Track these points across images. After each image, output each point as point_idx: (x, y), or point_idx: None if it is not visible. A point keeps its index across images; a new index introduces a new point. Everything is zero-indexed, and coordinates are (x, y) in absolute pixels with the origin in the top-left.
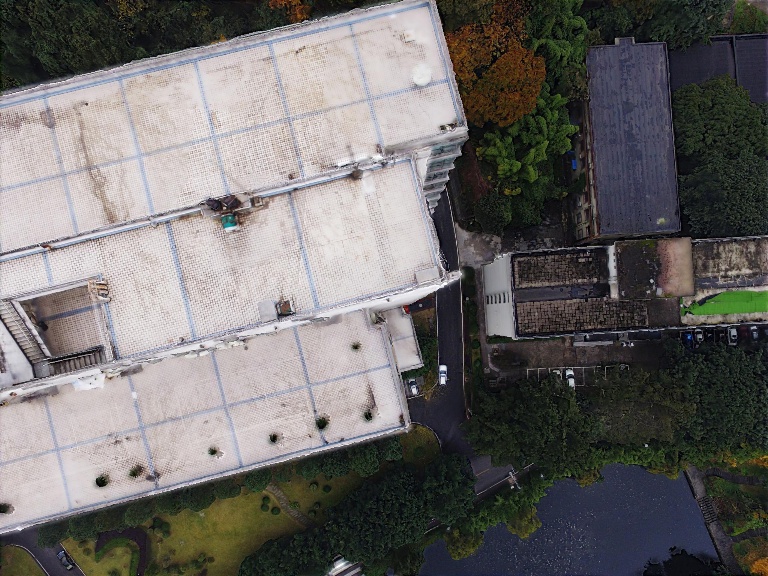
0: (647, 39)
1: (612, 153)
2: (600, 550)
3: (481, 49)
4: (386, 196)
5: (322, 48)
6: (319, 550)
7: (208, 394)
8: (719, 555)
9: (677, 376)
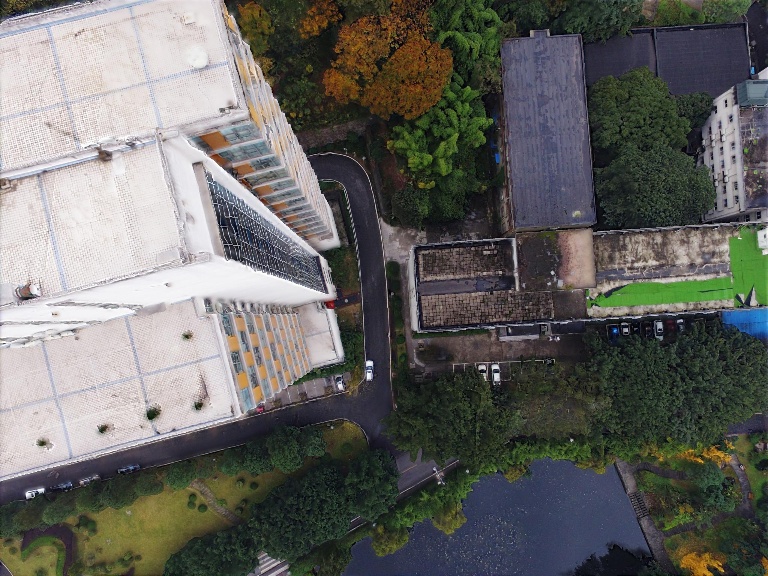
0: (563, 31)
1: (527, 146)
2: (531, 546)
3: (377, 41)
4: (135, 177)
5: (101, 31)
6: (241, 547)
7: (38, 385)
8: (651, 550)
9: (592, 369)
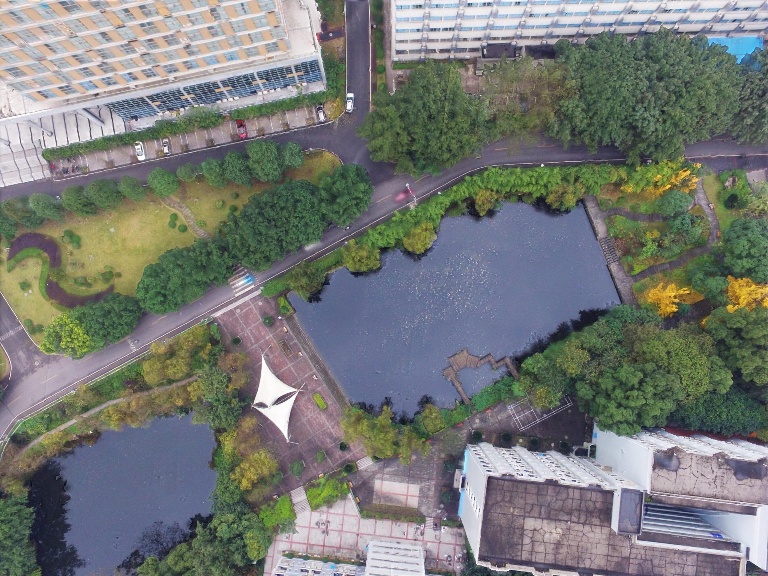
0: None
1: None
2: (501, 286)
3: None
4: None
5: None
6: (216, 249)
7: None
8: (620, 296)
9: (560, 60)
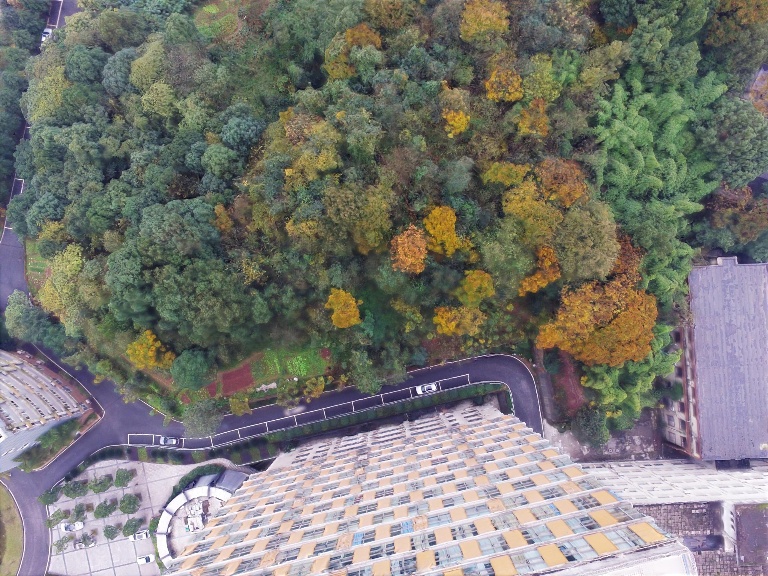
0: (749, 257)
1: (714, 375)
2: None
3: None
4: None
5: None
6: None
7: None
8: None
9: None
